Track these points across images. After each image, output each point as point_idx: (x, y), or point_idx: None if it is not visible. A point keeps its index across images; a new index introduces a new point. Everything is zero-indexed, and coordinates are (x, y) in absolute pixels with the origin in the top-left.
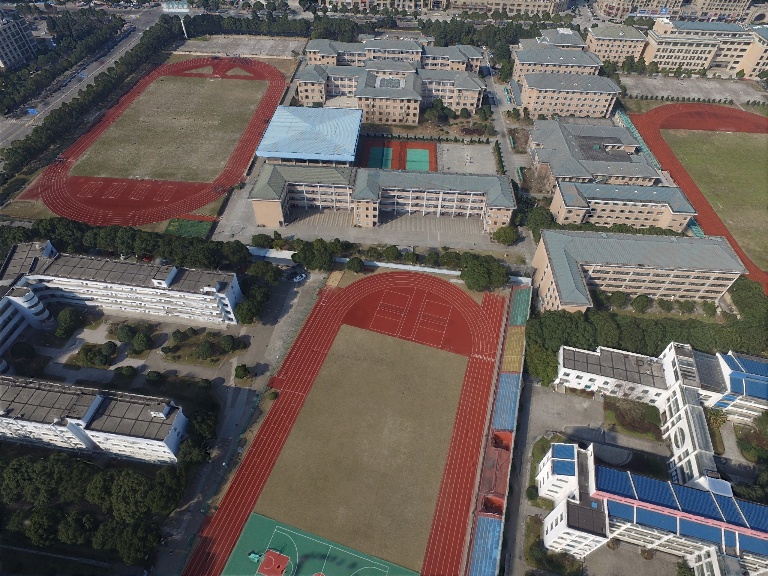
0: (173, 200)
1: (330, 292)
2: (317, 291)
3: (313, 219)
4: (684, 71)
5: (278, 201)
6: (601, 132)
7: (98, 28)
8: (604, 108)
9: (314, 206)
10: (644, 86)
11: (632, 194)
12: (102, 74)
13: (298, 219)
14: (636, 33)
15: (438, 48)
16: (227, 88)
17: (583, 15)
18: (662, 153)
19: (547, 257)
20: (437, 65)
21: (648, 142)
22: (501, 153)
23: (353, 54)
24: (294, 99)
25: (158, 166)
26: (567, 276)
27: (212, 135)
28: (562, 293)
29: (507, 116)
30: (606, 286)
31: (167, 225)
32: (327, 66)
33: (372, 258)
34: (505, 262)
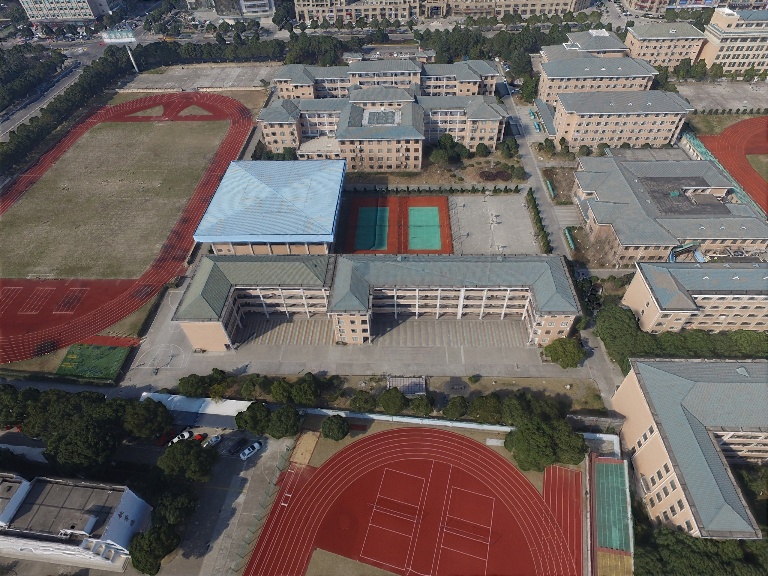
0: (80, 312)
1: (297, 478)
2: (276, 477)
3: (276, 333)
4: (755, 73)
5: (217, 322)
6: (676, 170)
7: (31, 67)
8: (669, 132)
9: (278, 311)
10: (708, 96)
11: (761, 282)
12: (21, 127)
13: (255, 335)
14: (691, 29)
15: (441, 66)
16: (178, 134)
17: (610, 11)
18: (760, 192)
19: (651, 417)
20: (441, 87)
21: (736, 176)
22: (537, 206)
23: (334, 80)
24: (260, 144)
25: (70, 256)
26: (700, 469)
27: (149, 203)
28: (698, 508)
29: (538, 150)
30: (747, 451)
31: (64, 357)
32: (299, 100)
33: (362, 410)
34: (569, 399)
